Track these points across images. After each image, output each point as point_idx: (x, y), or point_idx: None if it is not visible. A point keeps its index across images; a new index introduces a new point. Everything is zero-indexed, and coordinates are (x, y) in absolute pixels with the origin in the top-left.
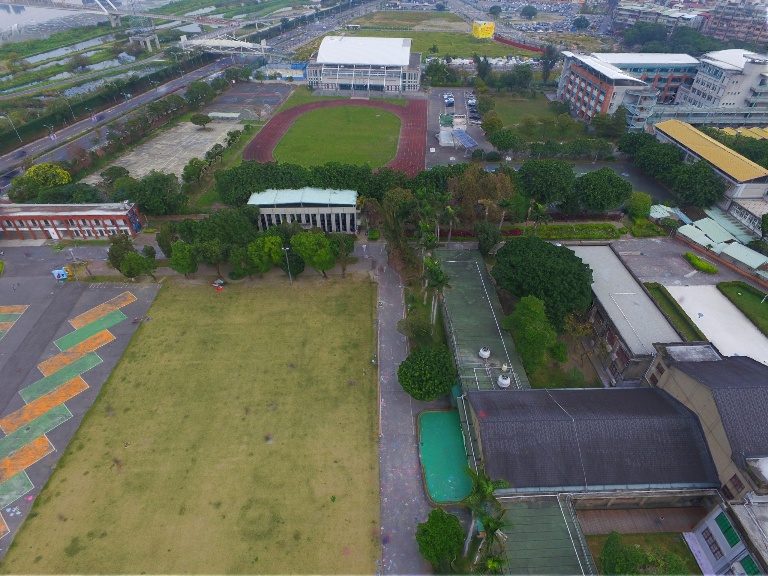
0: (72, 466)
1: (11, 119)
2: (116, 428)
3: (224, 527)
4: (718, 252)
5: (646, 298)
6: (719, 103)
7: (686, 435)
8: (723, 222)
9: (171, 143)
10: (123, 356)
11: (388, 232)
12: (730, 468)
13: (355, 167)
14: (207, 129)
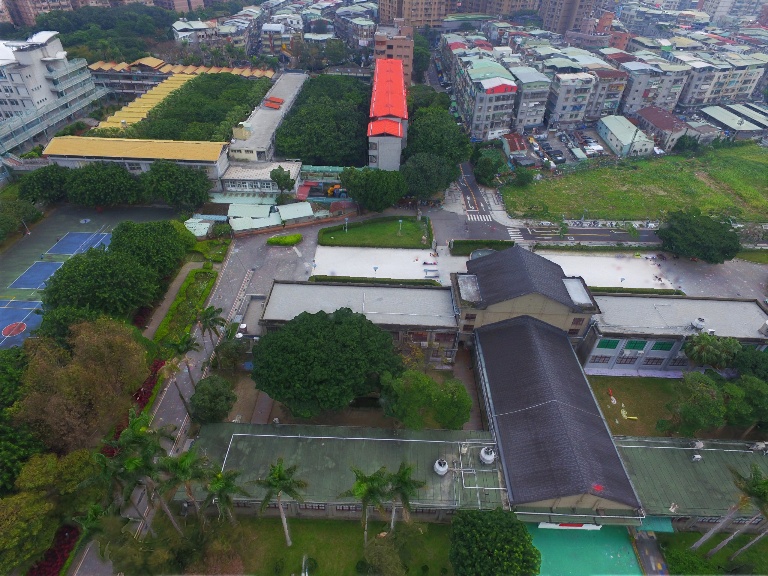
0: None
1: None
2: None
3: None
4: (280, 223)
5: (372, 289)
6: (33, 103)
7: (541, 330)
8: (237, 200)
9: None
10: None
11: (158, 575)
12: (569, 319)
13: None
14: None
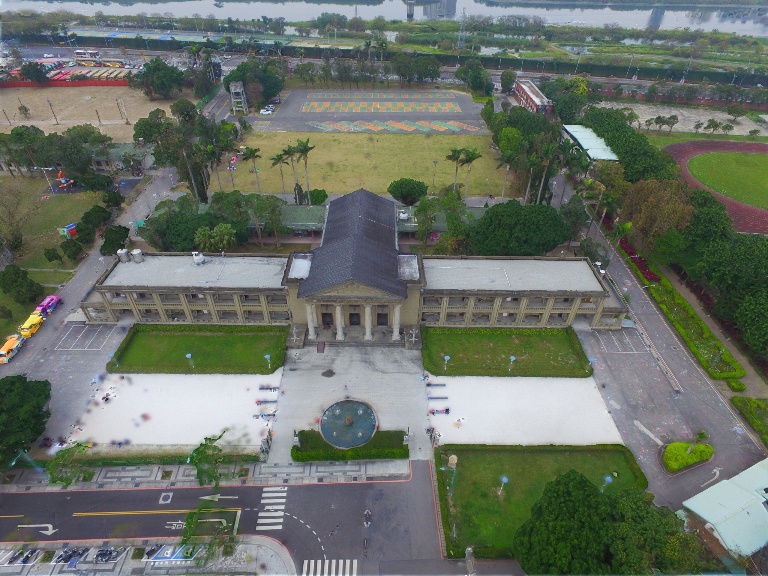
0: None
1: (652, 66)
2: None
3: None
4: None
5: None
6: None
7: None
8: None
9: (686, 114)
10: (429, 134)
11: None
12: None
13: (642, 144)
14: (735, 122)
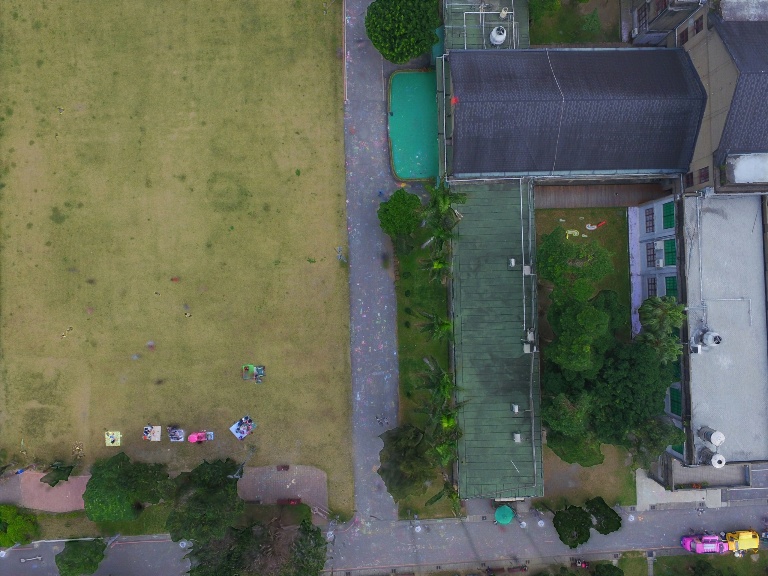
0: (12, 134)
1: None
2: (38, 88)
3: (195, 199)
4: None
5: None
6: None
7: (682, 119)
8: None
9: None
10: None
11: None
12: (706, 160)
13: None
14: None
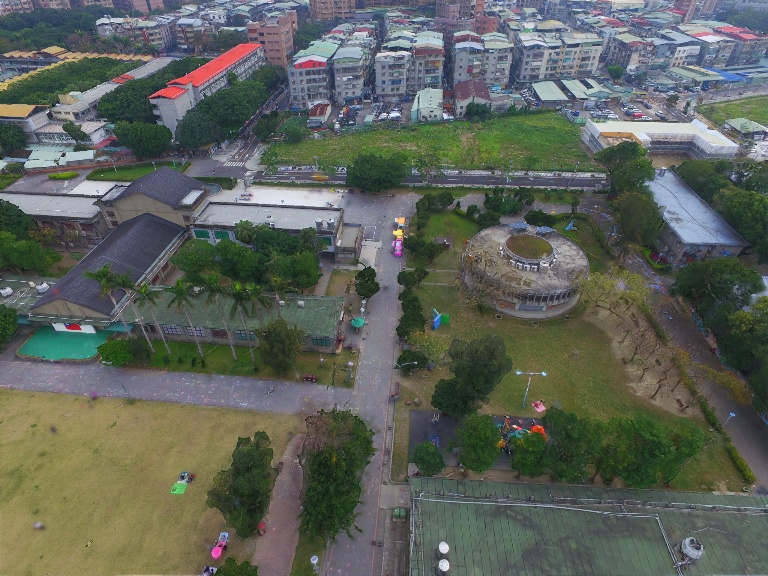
0: None
1: None
2: None
3: None
4: (65, 164)
5: (60, 197)
6: None
7: (153, 223)
8: (45, 149)
9: None
10: None
11: None
12: (179, 216)
13: None
14: None
